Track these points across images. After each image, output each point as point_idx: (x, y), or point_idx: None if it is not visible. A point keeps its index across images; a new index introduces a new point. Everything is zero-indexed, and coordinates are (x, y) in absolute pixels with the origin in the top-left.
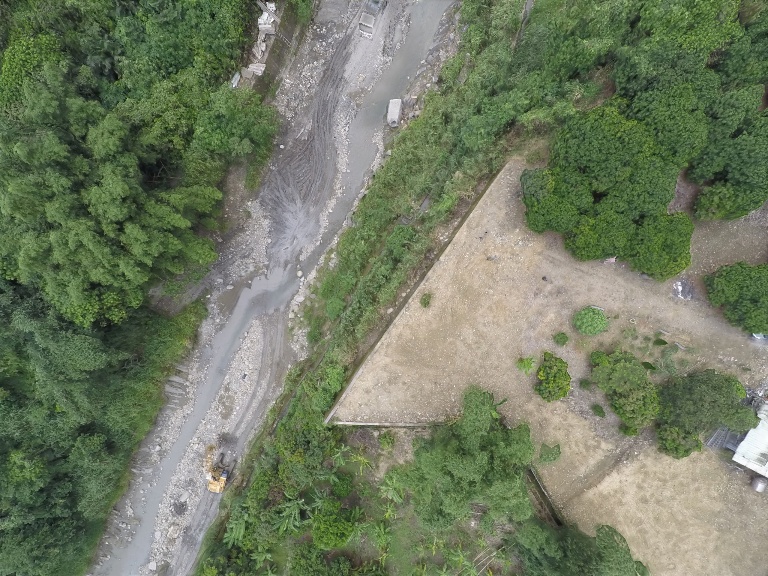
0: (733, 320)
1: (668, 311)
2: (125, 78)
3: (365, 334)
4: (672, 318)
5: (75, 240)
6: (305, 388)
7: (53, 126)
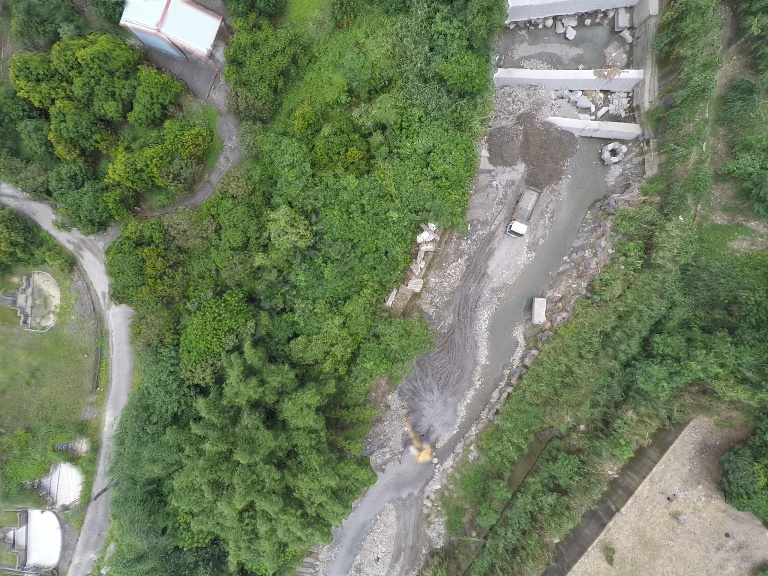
0: None
1: None
2: (297, 316)
3: None
4: None
5: (284, 529)
6: None
7: (262, 416)
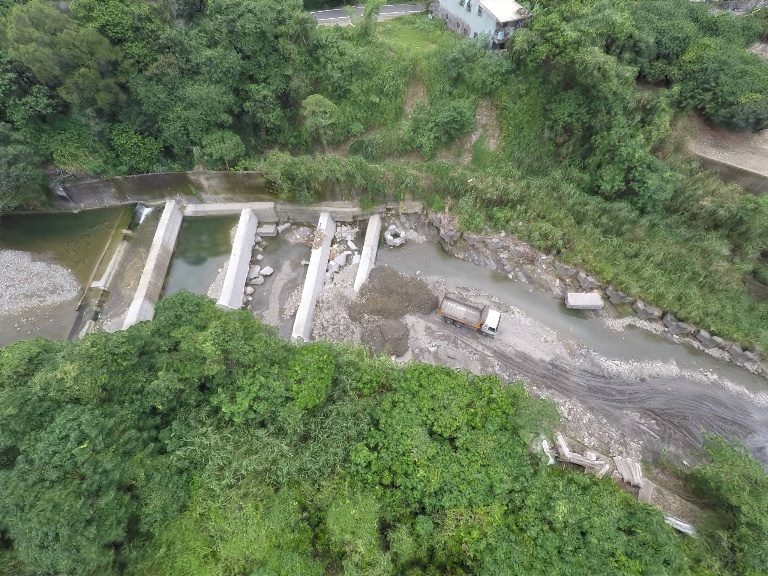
0: (760, 43)
1: None
2: None
3: None
4: None
5: None
6: None
7: None
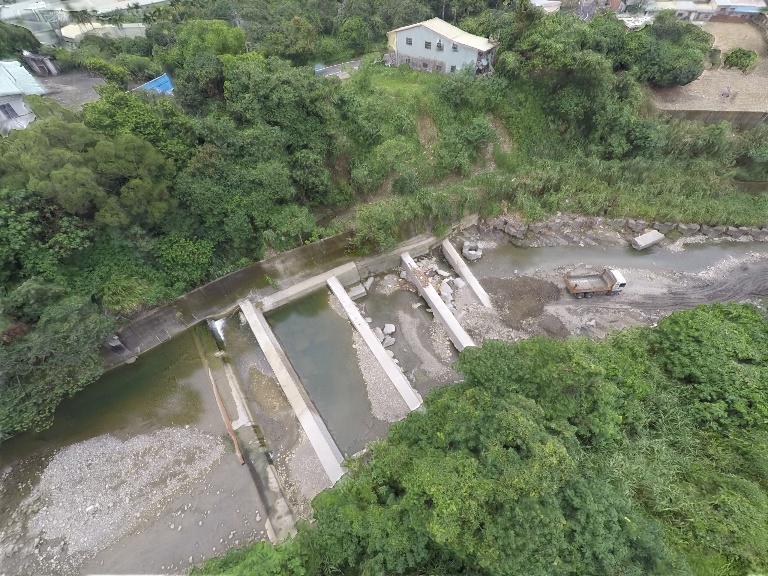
0: None
1: None
2: None
3: None
4: None
5: None
6: None
7: None
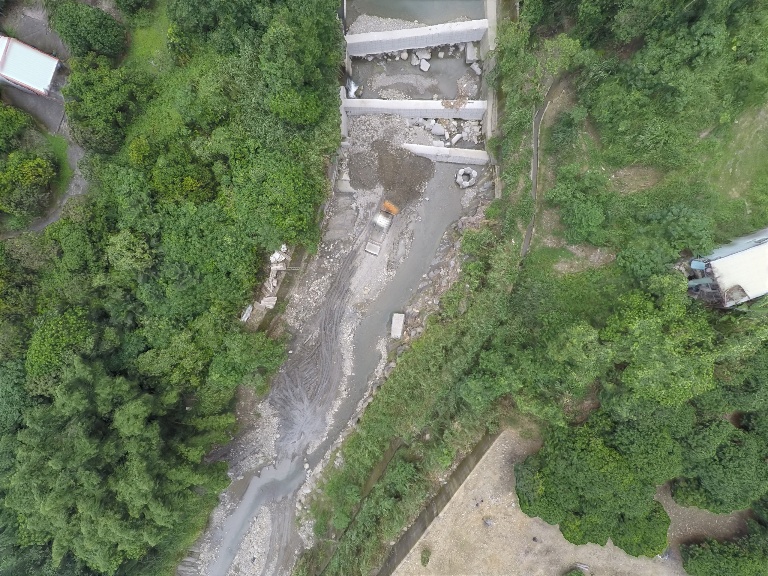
0: None
1: (647, 568)
2: (146, 332)
3: (369, 571)
4: (650, 574)
5: (104, 530)
6: None
7: (83, 426)
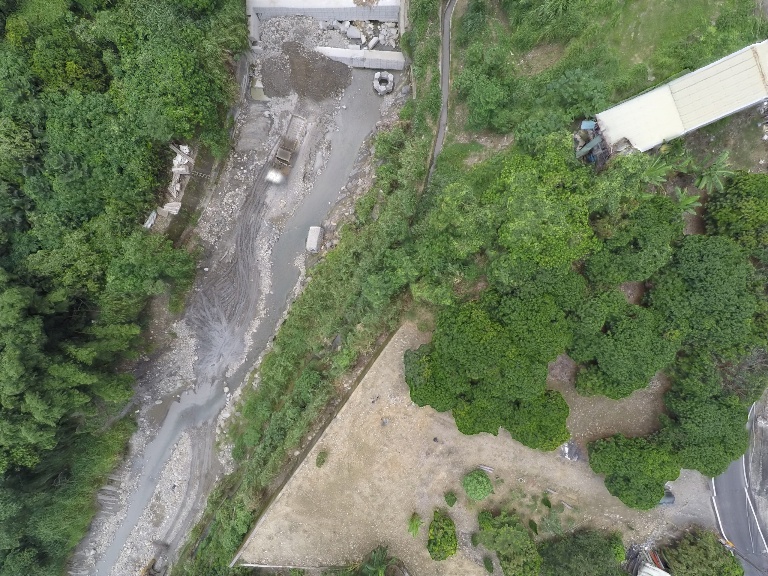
0: (611, 491)
1: (555, 471)
2: (36, 230)
3: (270, 480)
4: (559, 477)
5: None
6: (221, 517)
7: None
